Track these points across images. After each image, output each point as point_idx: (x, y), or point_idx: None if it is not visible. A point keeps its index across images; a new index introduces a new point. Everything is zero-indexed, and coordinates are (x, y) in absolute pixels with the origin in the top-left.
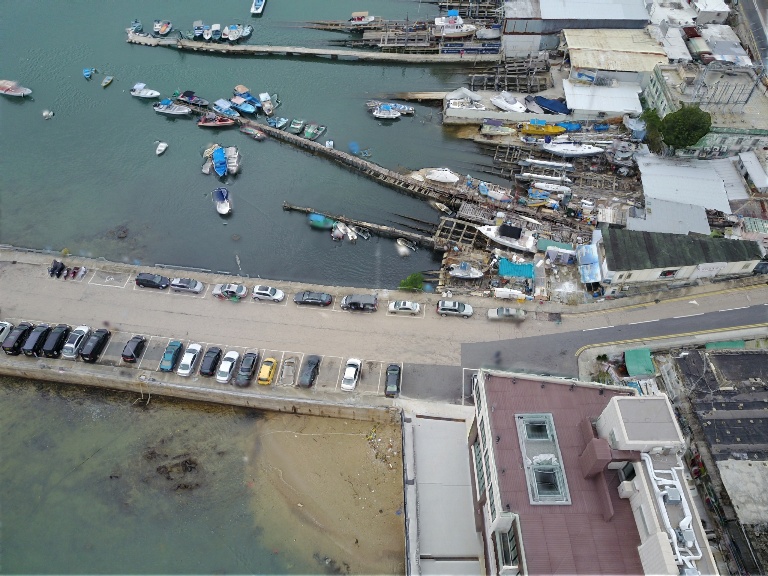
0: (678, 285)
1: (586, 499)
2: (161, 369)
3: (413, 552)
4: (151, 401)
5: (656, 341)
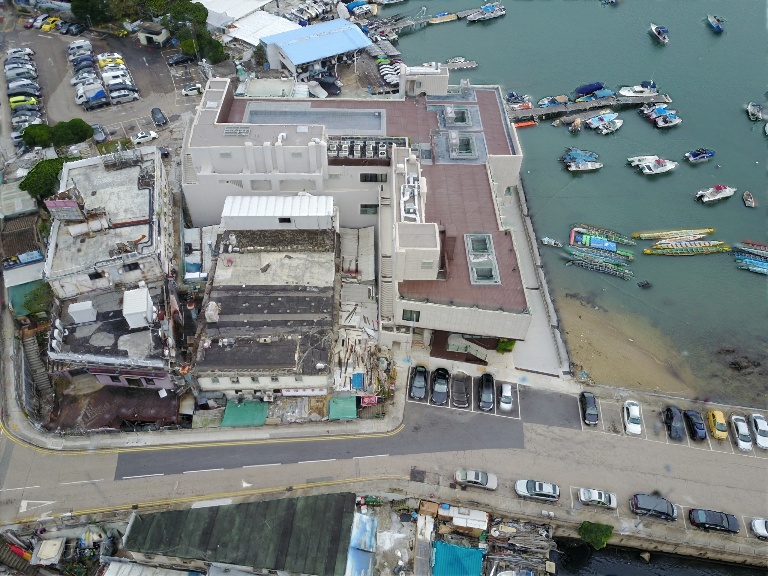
0: None
1: None
2: None
3: (545, 287)
4: None
5: (314, 434)
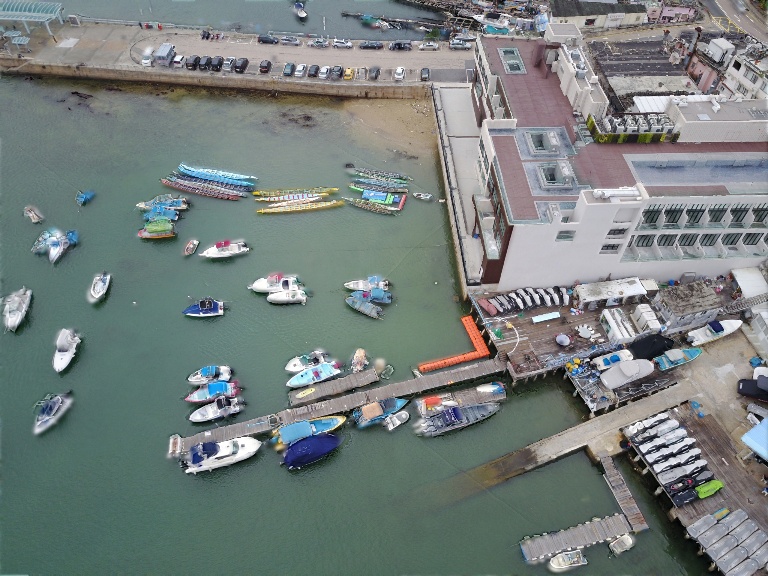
0: (597, 31)
1: (534, 73)
2: (284, 74)
3: (444, 132)
4: (278, 95)
5: None
